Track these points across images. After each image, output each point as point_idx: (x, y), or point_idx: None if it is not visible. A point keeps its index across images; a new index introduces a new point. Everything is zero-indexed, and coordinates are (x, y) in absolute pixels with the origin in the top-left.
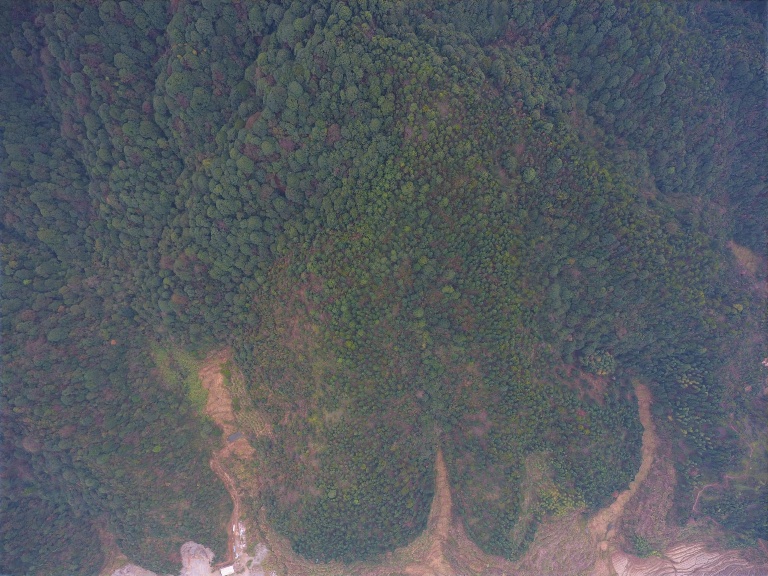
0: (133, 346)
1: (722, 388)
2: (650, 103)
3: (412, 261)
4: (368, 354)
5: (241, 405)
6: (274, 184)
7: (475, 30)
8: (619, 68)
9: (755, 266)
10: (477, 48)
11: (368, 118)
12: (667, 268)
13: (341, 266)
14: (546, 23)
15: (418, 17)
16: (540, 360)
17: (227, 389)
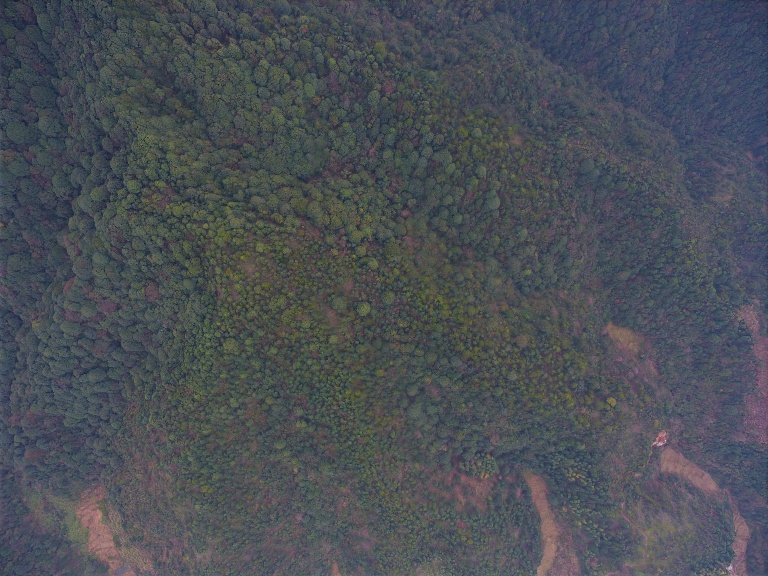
0: (1, 496)
1: (607, 481)
2: (490, 215)
3: (260, 400)
4: (230, 493)
5: (121, 542)
6: (107, 339)
7: (293, 169)
8: (449, 188)
9: (637, 346)
10: (291, 192)
11: (179, 280)
12: (523, 381)
13: (179, 421)
14: (371, 149)
15: (222, 172)
16: (409, 480)
17: (107, 525)
